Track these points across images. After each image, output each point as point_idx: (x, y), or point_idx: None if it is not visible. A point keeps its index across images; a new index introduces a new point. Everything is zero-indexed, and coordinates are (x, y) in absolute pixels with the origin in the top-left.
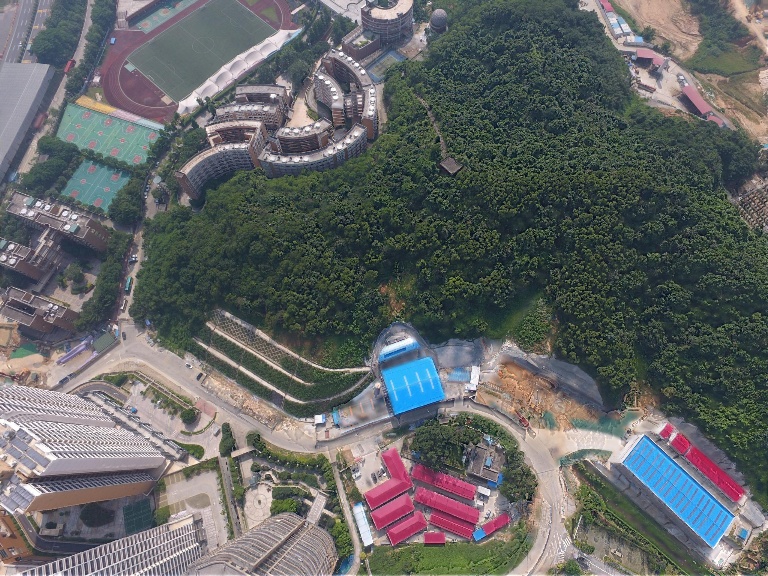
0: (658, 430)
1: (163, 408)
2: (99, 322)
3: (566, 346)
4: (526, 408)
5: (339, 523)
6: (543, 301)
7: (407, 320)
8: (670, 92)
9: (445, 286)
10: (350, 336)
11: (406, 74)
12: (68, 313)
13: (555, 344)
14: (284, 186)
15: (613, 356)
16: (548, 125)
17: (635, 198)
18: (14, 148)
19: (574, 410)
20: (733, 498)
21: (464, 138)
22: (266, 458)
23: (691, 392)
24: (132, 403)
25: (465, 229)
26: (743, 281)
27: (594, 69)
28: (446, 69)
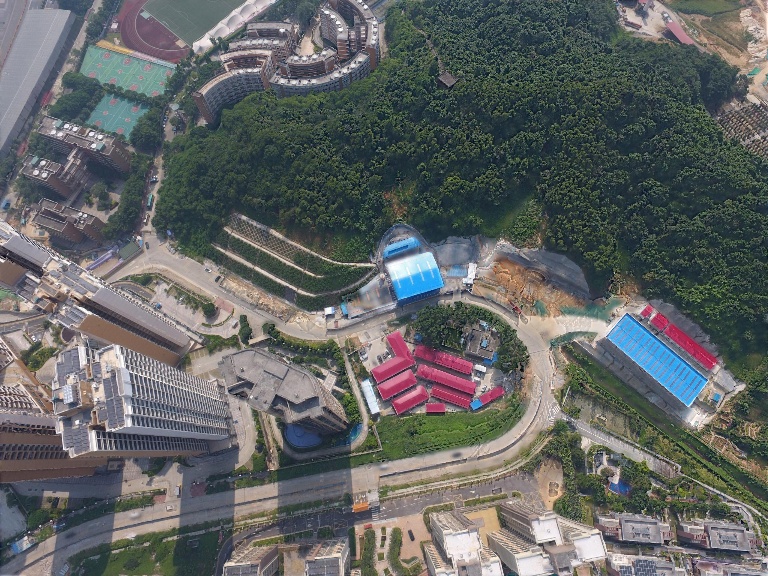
0: (639, 311)
1: (185, 304)
2: (124, 233)
3: (555, 236)
4: (519, 299)
5: (348, 395)
6: (534, 201)
7: (409, 222)
8: (655, 29)
9: (443, 186)
10: (357, 233)
11: (406, 12)
12: (96, 221)
13: (545, 236)
14: (294, 103)
15: (597, 243)
16: (538, 48)
17: (617, 101)
18: (40, 84)
19: (563, 299)
20: (707, 366)
21: (460, 60)
22: (281, 345)
23: (669, 274)
24: (157, 300)
25: (461, 133)
26: (716, 172)
27: (582, 1)
28: (444, 6)
